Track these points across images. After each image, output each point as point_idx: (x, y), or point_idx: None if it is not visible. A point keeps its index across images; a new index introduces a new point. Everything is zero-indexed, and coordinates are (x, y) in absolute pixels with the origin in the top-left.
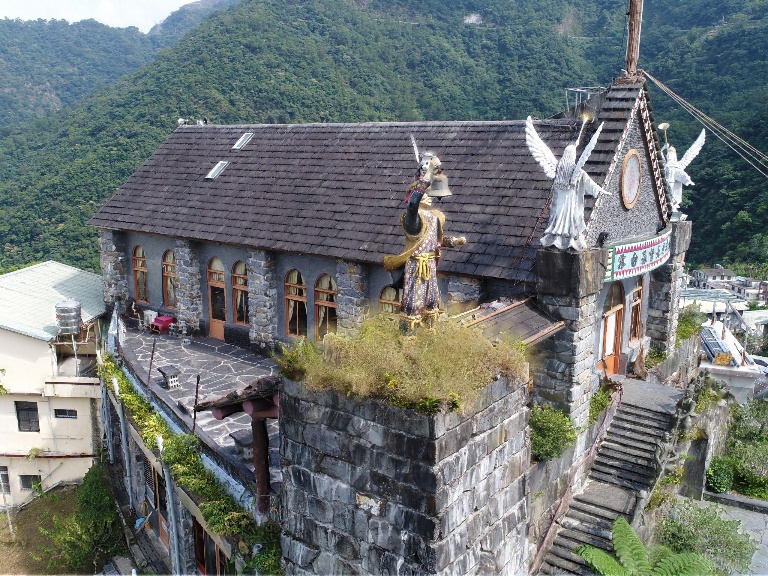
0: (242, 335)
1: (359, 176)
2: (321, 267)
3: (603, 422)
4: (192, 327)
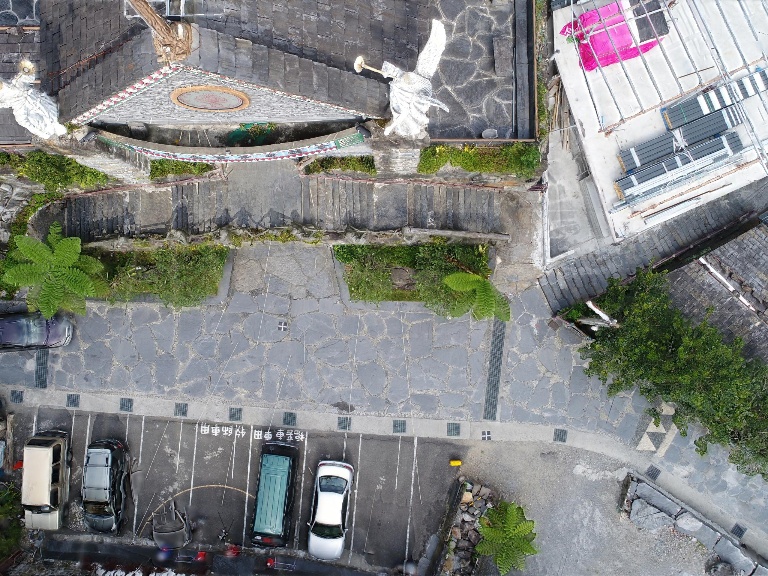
0: None
1: None
2: None
3: (182, 180)
4: None
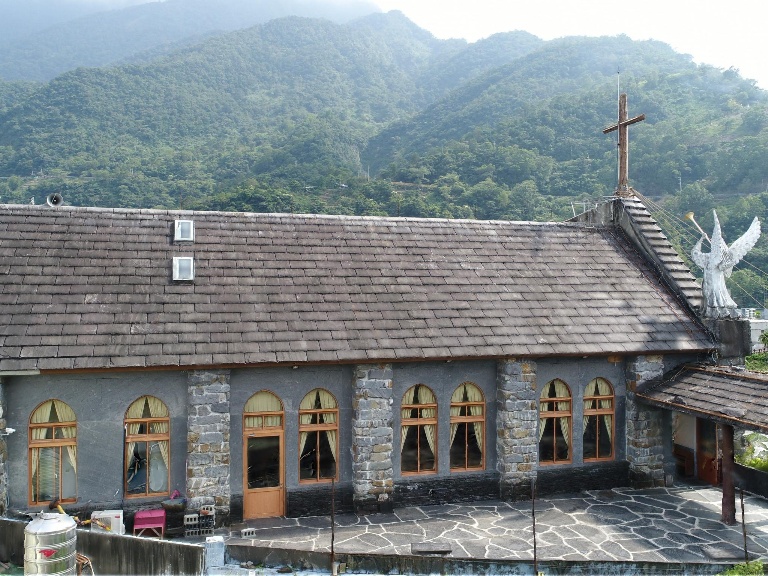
0: (328, 496)
1: (438, 271)
2: (462, 375)
3: None
4: (227, 510)
